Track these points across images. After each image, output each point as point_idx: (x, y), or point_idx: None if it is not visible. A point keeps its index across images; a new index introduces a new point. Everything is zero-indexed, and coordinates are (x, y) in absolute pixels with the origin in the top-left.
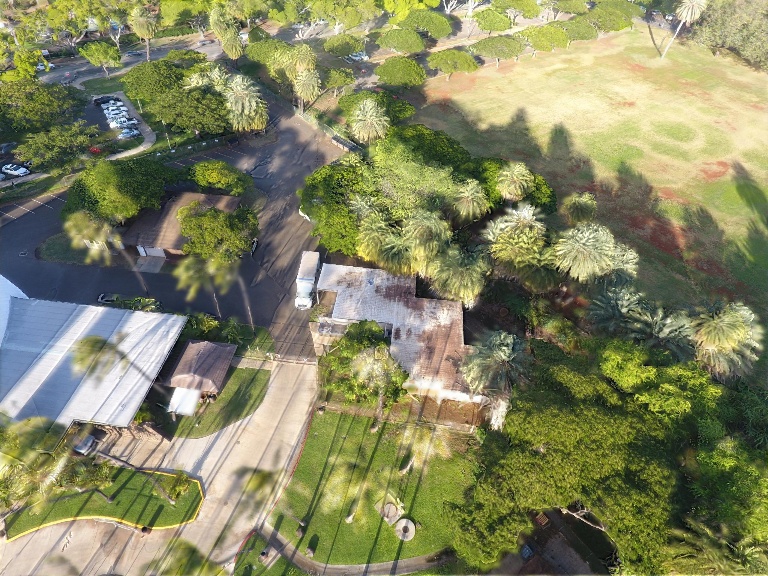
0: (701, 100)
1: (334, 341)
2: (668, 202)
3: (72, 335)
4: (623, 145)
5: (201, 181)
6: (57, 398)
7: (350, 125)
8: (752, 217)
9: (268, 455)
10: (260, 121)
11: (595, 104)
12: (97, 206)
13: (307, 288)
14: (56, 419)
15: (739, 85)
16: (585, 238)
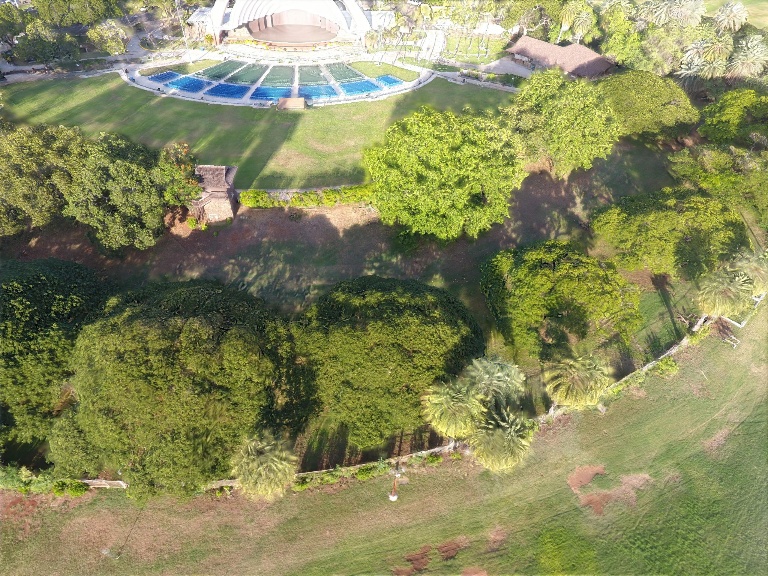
0: None
1: None
2: None
3: None
4: None
5: None
6: None
7: None
8: None
9: None
10: None
11: None
12: None
13: None
14: (372, 25)
15: None
16: None
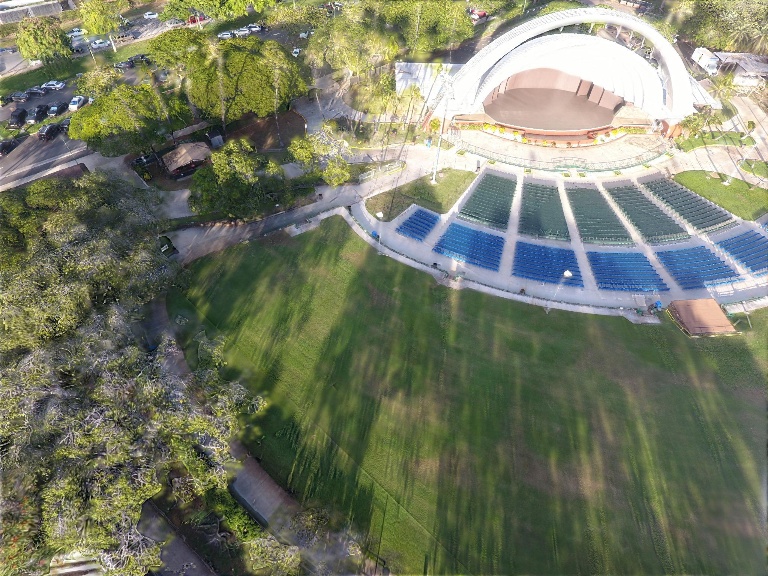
0: None
1: (744, 88)
2: None
3: None
4: None
5: None
6: None
7: None
8: None
9: (764, 125)
10: None
11: None
12: None
13: (714, 64)
14: None
15: None
16: None
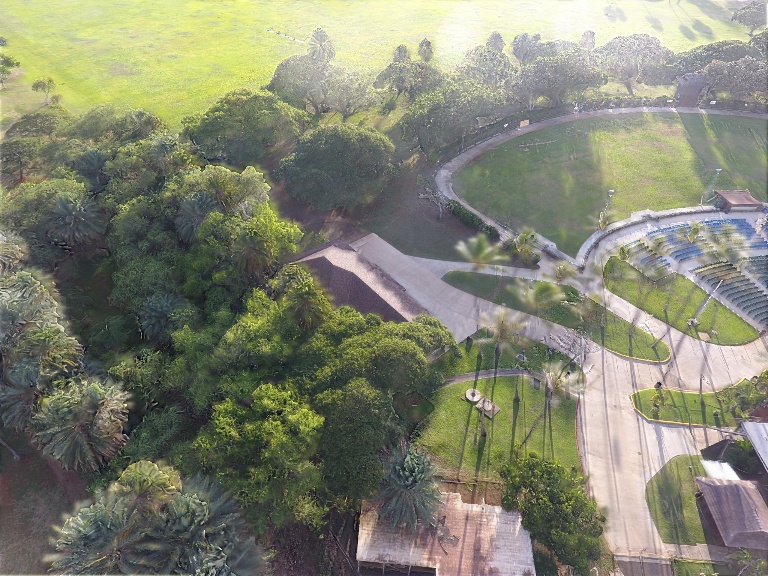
0: None
1: None
2: None
3: None
4: None
5: None
6: None
7: None
8: None
9: (606, 444)
10: None
11: None
12: None
13: None
14: None
15: None
16: None
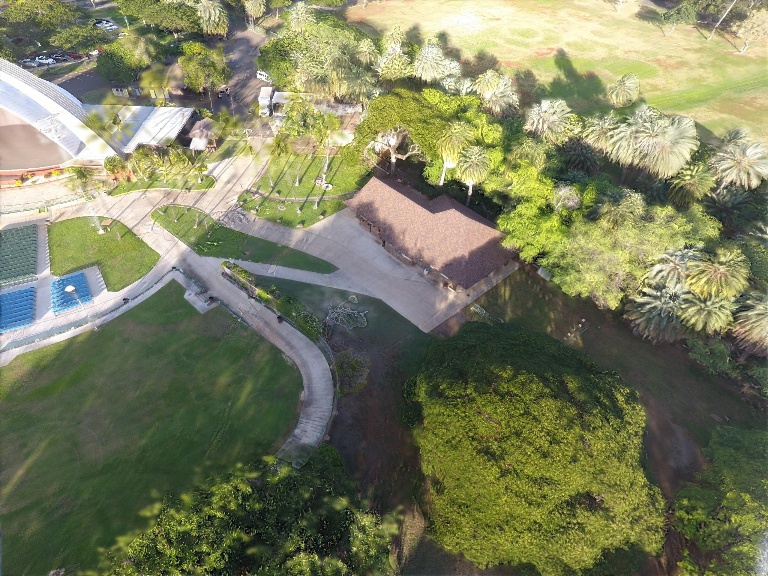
0: (549, 16)
1: None
2: (507, 67)
3: (125, 116)
4: (485, 41)
5: (188, 52)
6: (126, 136)
7: (289, 28)
8: (559, 73)
9: (250, 168)
10: (222, 27)
11: (472, 19)
12: (123, 59)
13: (266, 103)
14: (129, 142)
15: (580, 7)
16: (426, 53)
